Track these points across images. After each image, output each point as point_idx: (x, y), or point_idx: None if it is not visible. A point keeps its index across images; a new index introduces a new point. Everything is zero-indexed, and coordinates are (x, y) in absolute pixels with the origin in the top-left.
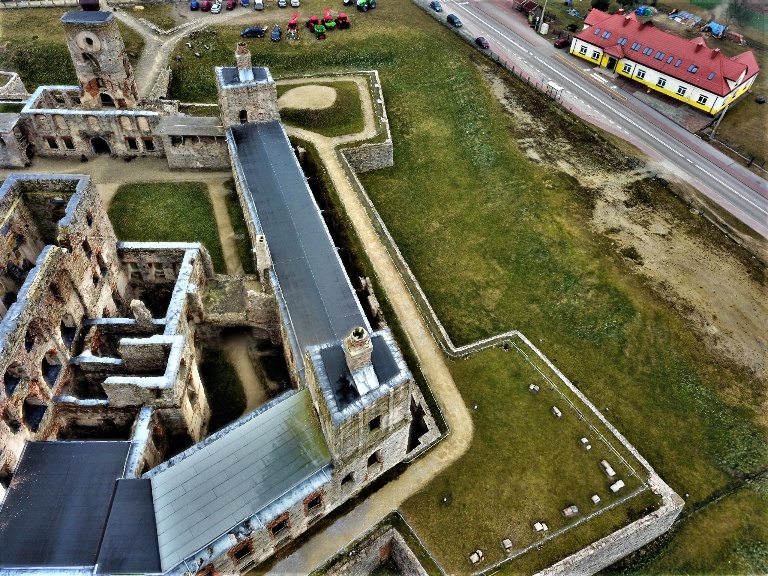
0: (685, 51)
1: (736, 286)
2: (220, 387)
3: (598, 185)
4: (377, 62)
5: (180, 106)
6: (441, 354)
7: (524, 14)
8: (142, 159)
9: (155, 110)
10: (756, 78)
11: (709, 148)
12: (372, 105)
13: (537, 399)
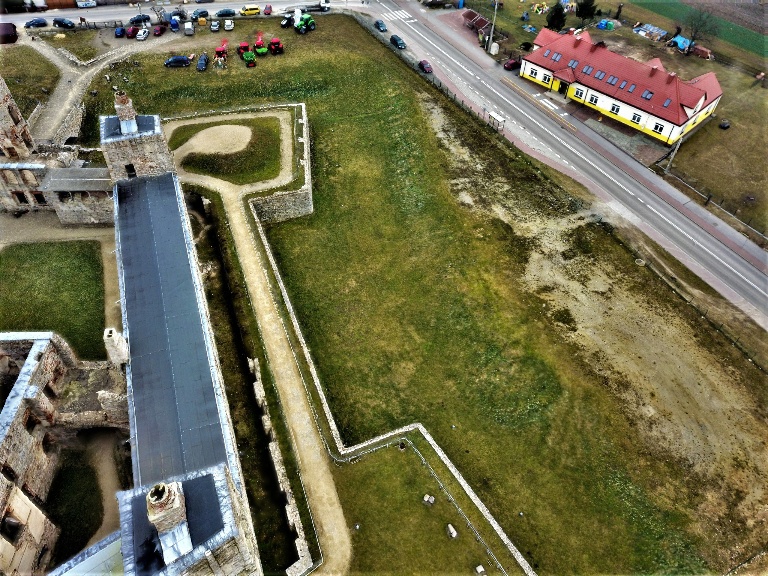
0: (639, 75)
1: (680, 354)
2: (75, 498)
3: (534, 233)
4: (310, 91)
5: (81, 152)
6: (327, 457)
7: (475, 32)
8: (34, 214)
9: (50, 158)
10: (722, 99)
11: (663, 184)
12: (292, 145)
13: (431, 514)
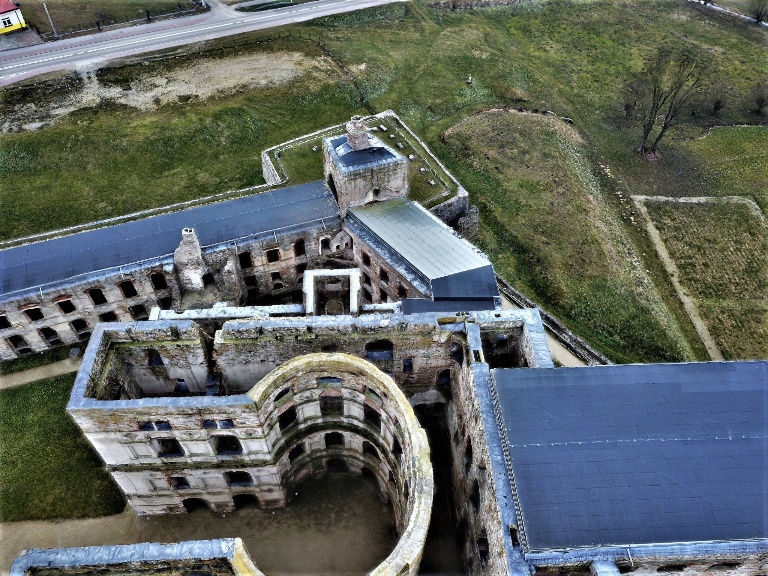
0: None
1: (227, 65)
2: None
3: (97, 98)
4: None
5: None
6: None
7: None
8: None
9: None
10: None
11: (68, 41)
12: None
13: None
